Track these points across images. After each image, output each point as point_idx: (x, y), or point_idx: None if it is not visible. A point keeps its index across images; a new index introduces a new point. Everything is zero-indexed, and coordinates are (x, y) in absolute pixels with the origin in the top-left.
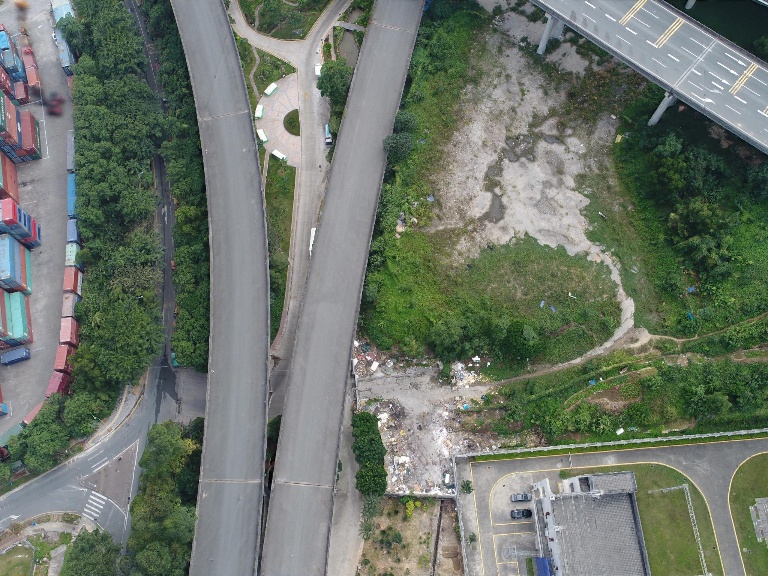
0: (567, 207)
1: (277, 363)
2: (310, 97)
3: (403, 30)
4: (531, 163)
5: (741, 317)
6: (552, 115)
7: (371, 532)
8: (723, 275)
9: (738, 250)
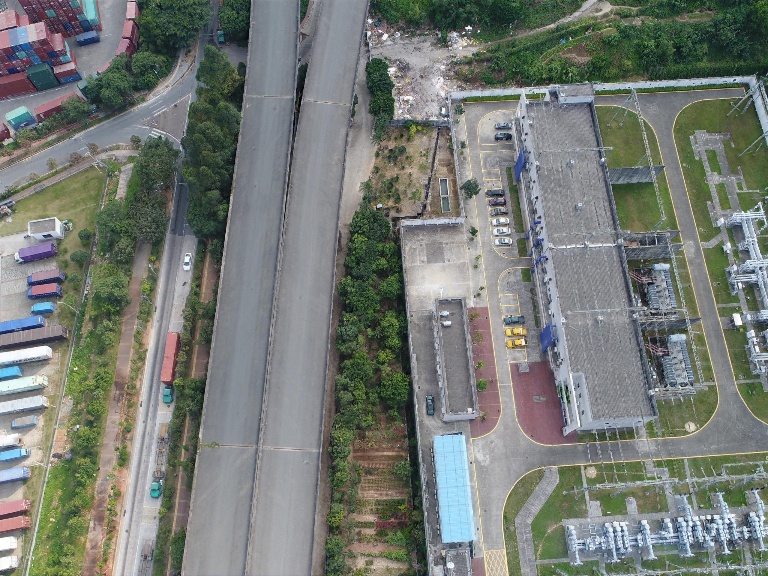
0: None
1: (305, 38)
2: None
3: None
4: None
5: None
6: None
7: (381, 152)
8: None
9: None
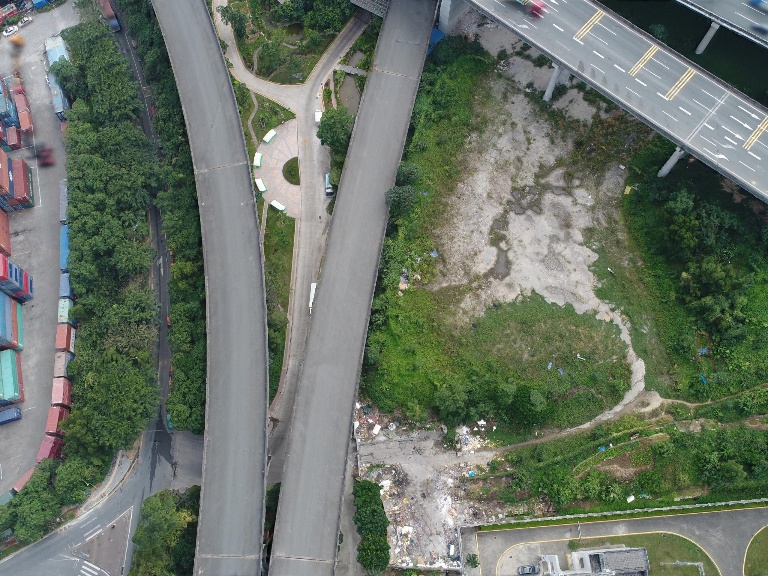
0: (575, 263)
1: (276, 425)
2: (310, 144)
3: (405, 76)
4: (537, 216)
5: (756, 381)
6: (559, 165)
7: None
8: (737, 338)
9: (752, 311)
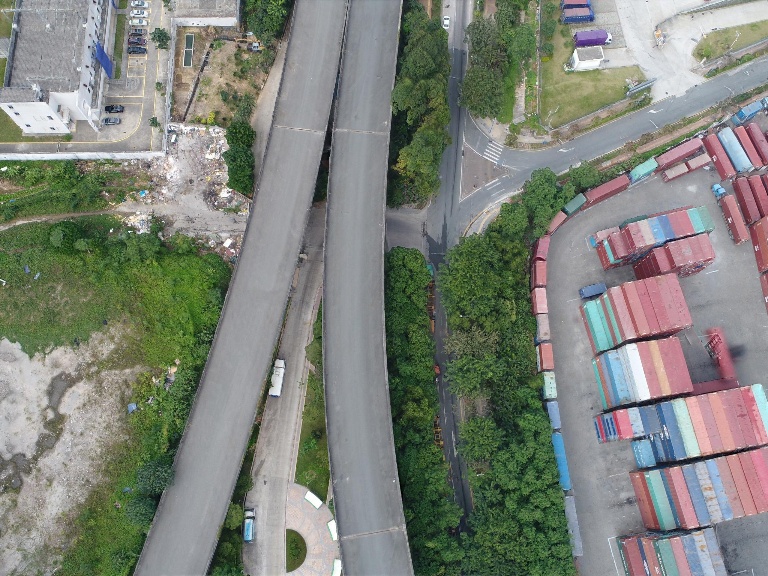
0: None
1: None
2: None
3: None
4: None
5: None
6: None
7: None
8: None
9: None
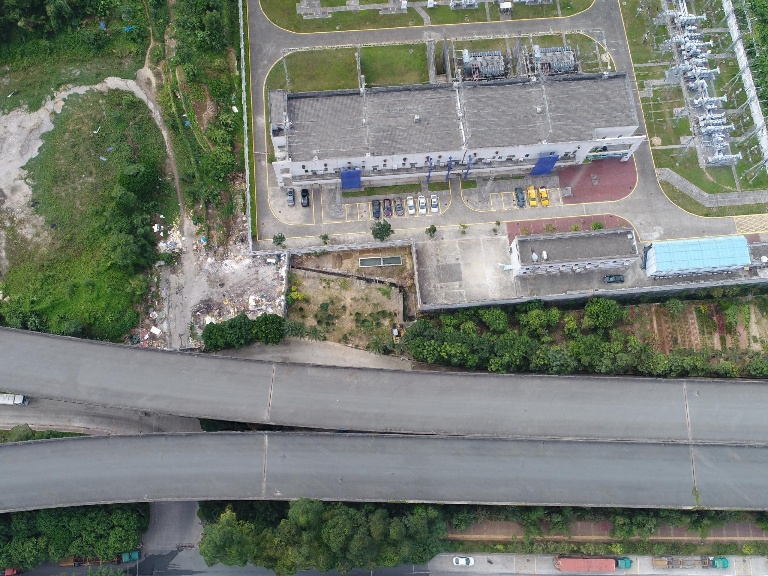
0: None
1: None
2: None
3: None
4: None
5: None
6: None
7: None
8: None
9: None
